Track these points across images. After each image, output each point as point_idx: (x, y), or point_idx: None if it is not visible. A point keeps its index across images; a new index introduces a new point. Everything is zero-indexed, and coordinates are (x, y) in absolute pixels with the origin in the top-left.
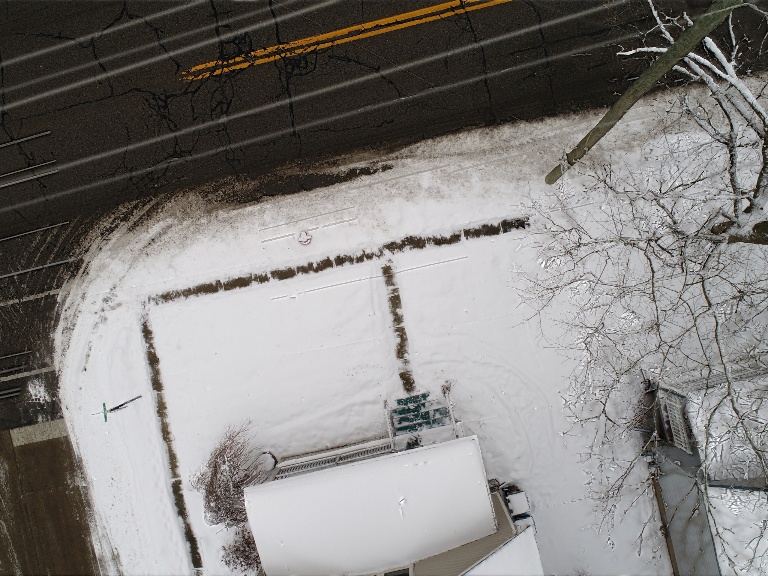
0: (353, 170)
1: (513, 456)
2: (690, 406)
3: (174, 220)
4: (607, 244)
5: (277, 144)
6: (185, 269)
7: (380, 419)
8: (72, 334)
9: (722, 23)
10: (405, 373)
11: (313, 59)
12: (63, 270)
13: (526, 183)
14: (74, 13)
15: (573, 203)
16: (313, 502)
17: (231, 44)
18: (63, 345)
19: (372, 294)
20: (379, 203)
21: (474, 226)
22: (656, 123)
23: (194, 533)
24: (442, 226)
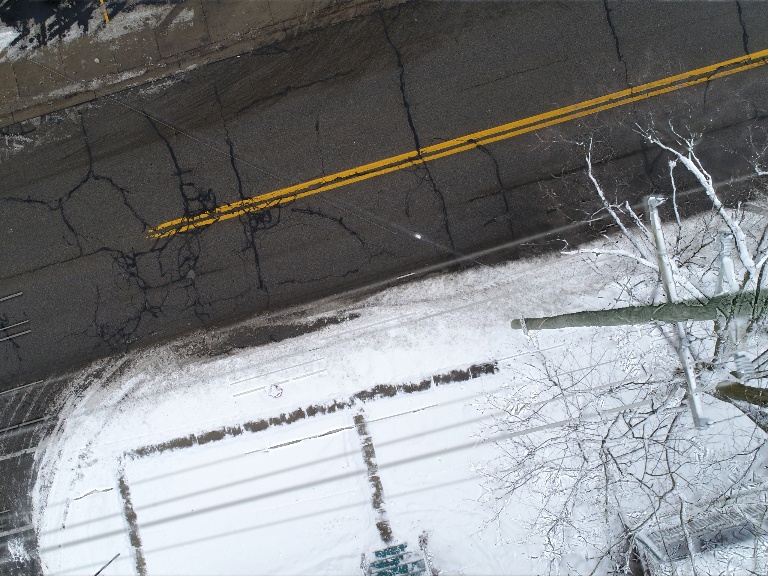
0: (321, 320)
1: None
2: None
3: (146, 375)
4: (565, 431)
5: (245, 297)
6: (159, 425)
7: (358, 573)
8: (49, 492)
9: (677, 163)
10: (382, 523)
11: (276, 213)
12: (39, 428)
13: (492, 329)
14: (42, 177)
15: (540, 346)
16: None
17: (196, 201)
18: (41, 503)
19: (345, 445)
20: (347, 354)
21: (443, 372)
22: (618, 265)
23: None
24: (411, 374)
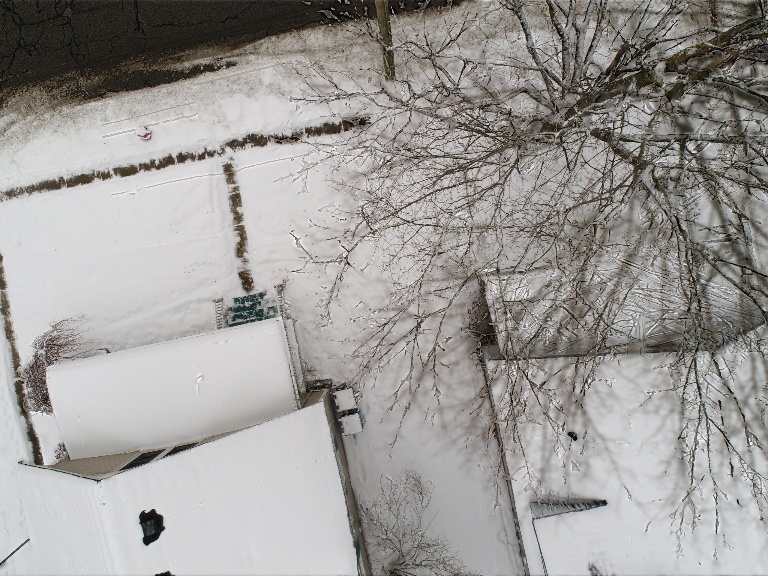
0: (197, 66)
1: (348, 356)
2: (488, 286)
3: (18, 115)
4: (391, 110)
5: (121, 39)
6: (27, 164)
7: None
8: None
9: None
10: (244, 272)
11: None
12: None
13: (366, 80)
14: None
15: None
16: (113, 379)
17: None
18: None
19: (211, 191)
20: (220, 99)
21: (315, 124)
22: None
23: (36, 433)
24: (283, 123)
